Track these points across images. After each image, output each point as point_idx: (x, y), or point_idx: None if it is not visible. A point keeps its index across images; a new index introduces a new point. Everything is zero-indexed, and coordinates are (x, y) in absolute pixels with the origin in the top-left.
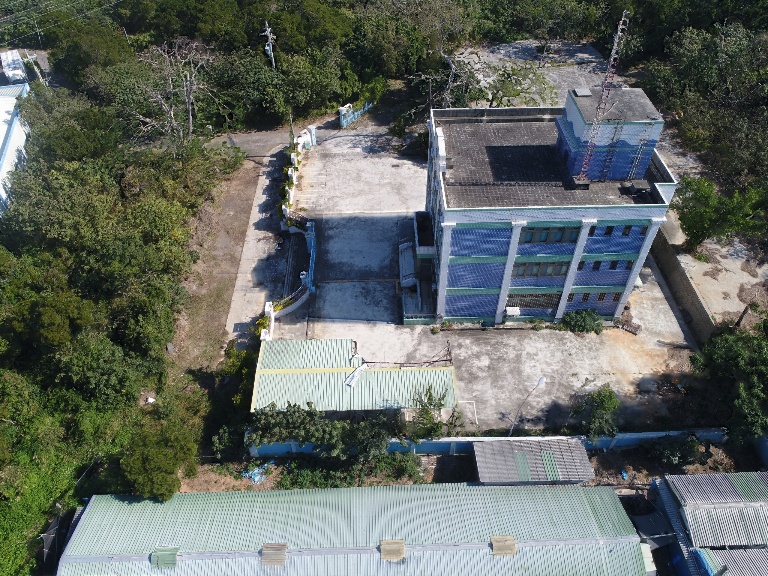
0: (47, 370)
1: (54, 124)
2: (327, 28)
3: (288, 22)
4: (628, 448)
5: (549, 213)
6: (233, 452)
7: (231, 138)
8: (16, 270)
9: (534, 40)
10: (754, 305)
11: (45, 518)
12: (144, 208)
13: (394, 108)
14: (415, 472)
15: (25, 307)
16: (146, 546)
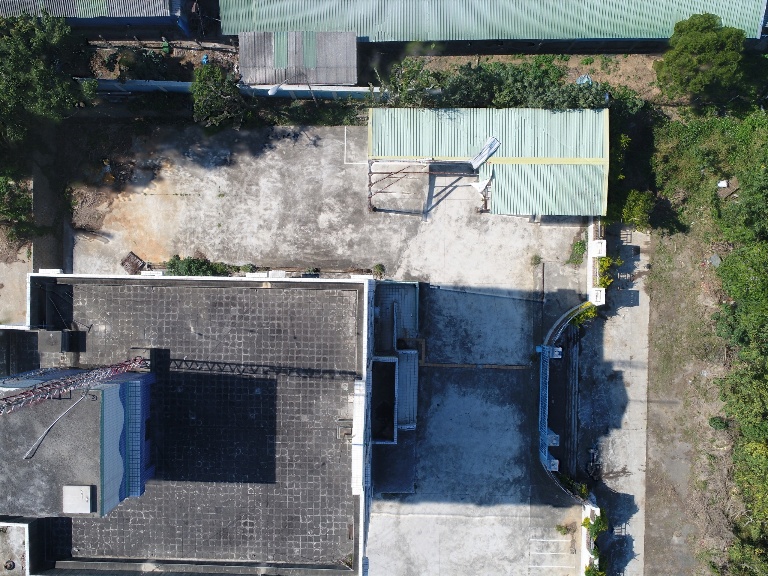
0: None
1: None
2: None
3: None
4: None
5: None
6: None
7: None
8: None
9: None
10: None
11: None
12: None
13: None
14: None
15: None
16: None
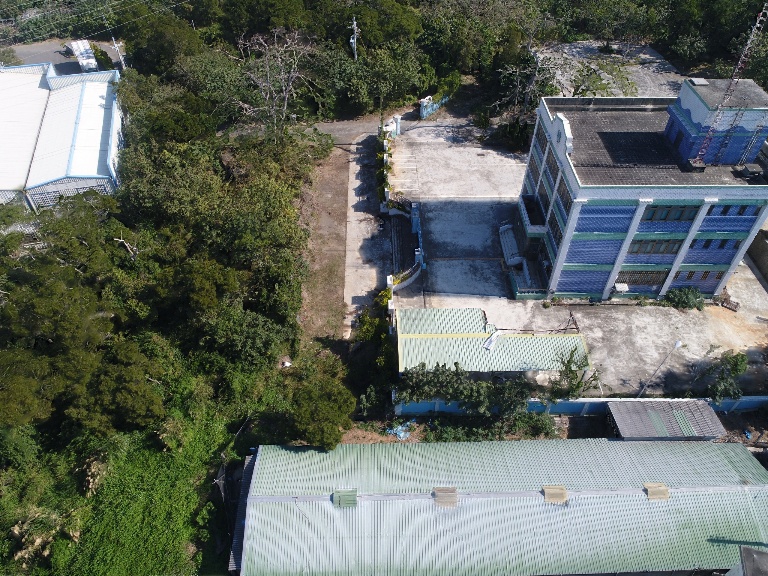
0: (184, 335)
1: (159, 107)
2: (403, 24)
3: (368, 17)
4: (748, 411)
5: (675, 192)
6: (378, 410)
7: (314, 127)
8: (139, 243)
9: (594, 41)
10: None
11: (206, 468)
12: (260, 187)
13: (469, 101)
14: (551, 430)
15: (170, 274)
16: (325, 488)
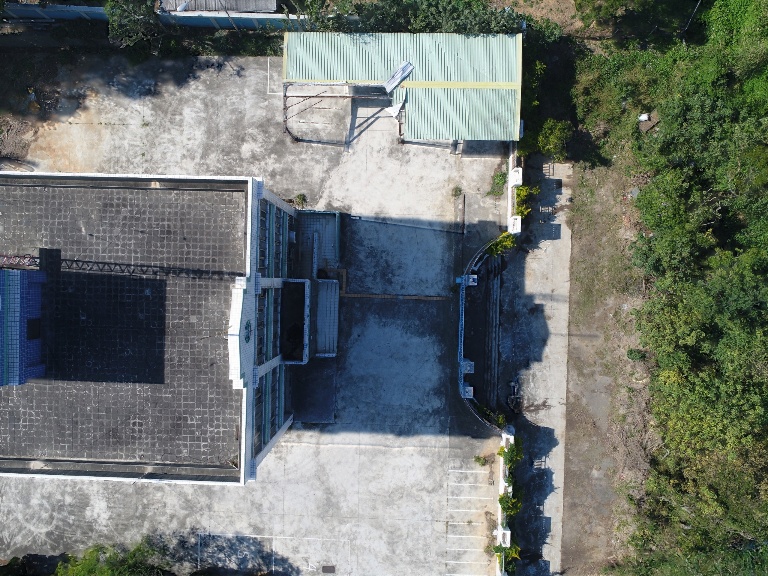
0: None
1: None
2: None
3: None
4: None
5: None
6: None
7: None
8: None
9: None
10: None
11: None
12: None
13: None
14: None
15: None
16: None
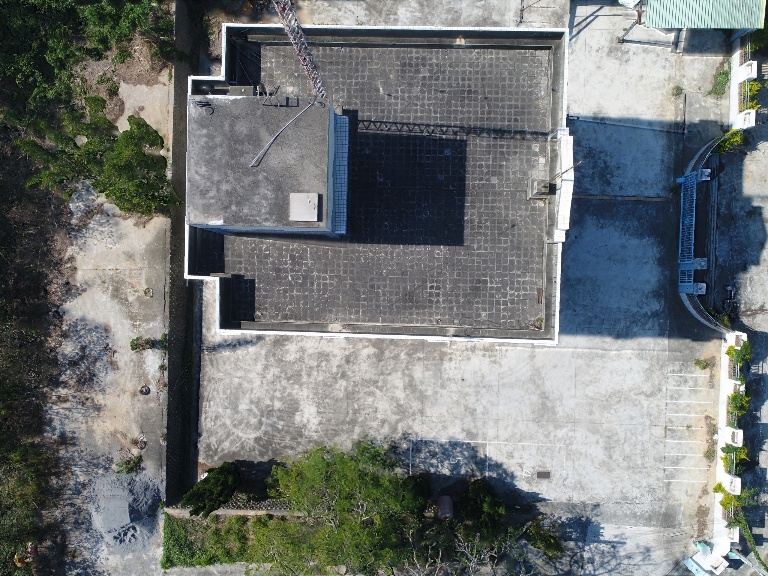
0: None
1: None
2: None
3: None
4: None
5: None
6: None
7: None
8: None
9: None
10: (112, 91)
11: None
12: None
13: None
14: None
15: None
16: None
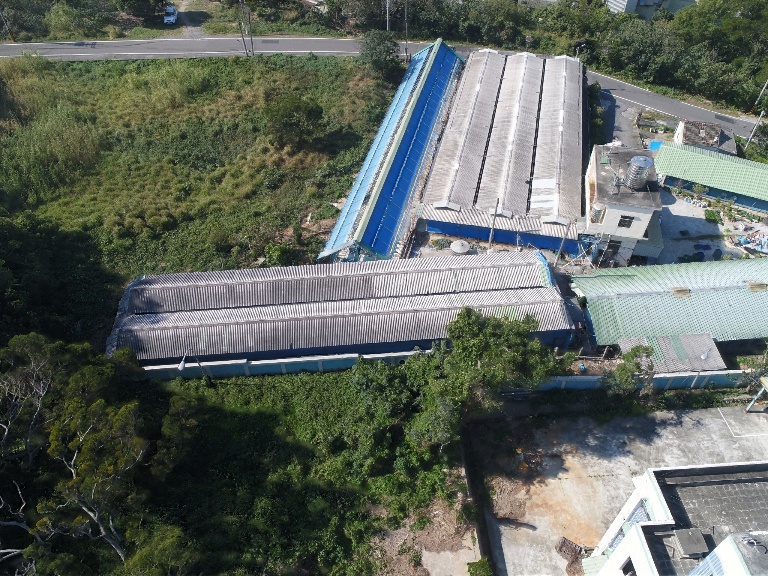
0: None
1: None
2: None
3: None
4: None
5: None
6: None
7: None
8: None
9: None
10: (416, 561)
11: None
12: None
13: None
14: None
15: None
16: None
